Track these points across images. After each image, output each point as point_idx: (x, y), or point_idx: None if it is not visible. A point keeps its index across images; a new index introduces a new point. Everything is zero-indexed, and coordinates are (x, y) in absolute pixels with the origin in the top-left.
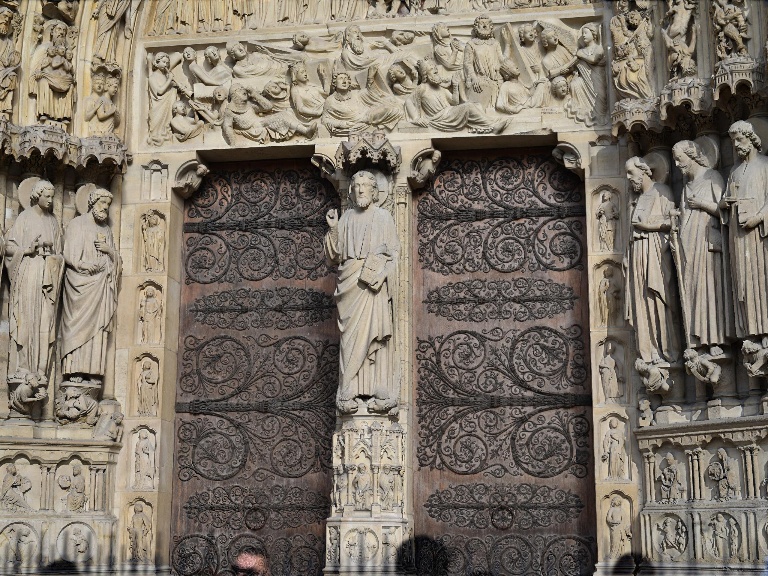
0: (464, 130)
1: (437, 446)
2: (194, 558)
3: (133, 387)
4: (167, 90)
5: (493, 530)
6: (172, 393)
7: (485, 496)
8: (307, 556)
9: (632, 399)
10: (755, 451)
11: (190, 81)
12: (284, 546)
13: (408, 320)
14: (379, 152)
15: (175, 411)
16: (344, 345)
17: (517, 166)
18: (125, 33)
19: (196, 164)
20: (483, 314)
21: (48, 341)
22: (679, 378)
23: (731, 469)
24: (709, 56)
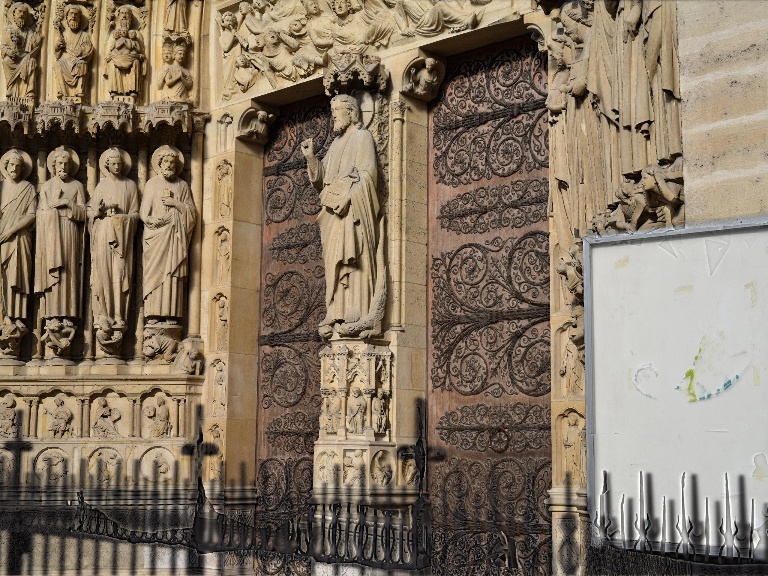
0: (445, 31)
1: (446, 367)
2: (272, 479)
3: (213, 325)
4: (233, 46)
5: (492, 453)
6: (251, 328)
7: (485, 417)
8: None
9: None
10: None
11: None
12: None
13: (405, 239)
14: (348, 73)
15: (259, 344)
16: None
17: (516, 58)
18: (194, 2)
19: (254, 111)
20: (485, 224)
21: (120, 290)
22: None
23: None
24: None
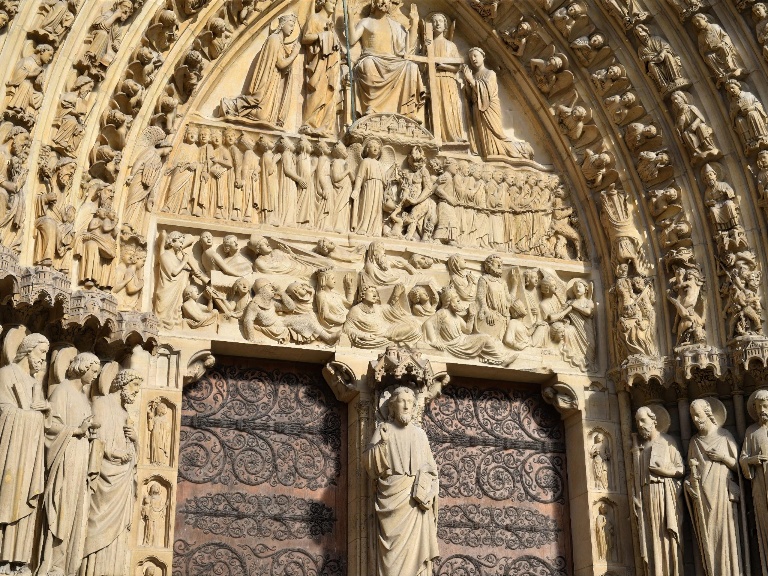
0: (476, 359)
1: None
2: None
3: None
4: (180, 272)
5: None
6: None
7: None
8: None
9: None
10: None
11: (200, 266)
12: None
13: None
14: (423, 371)
15: None
16: (389, 563)
17: (505, 398)
18: (147, 205)
19: (208, 354)
20: (478, 539)
21: None
22: None
23: None
24: (717, 329)
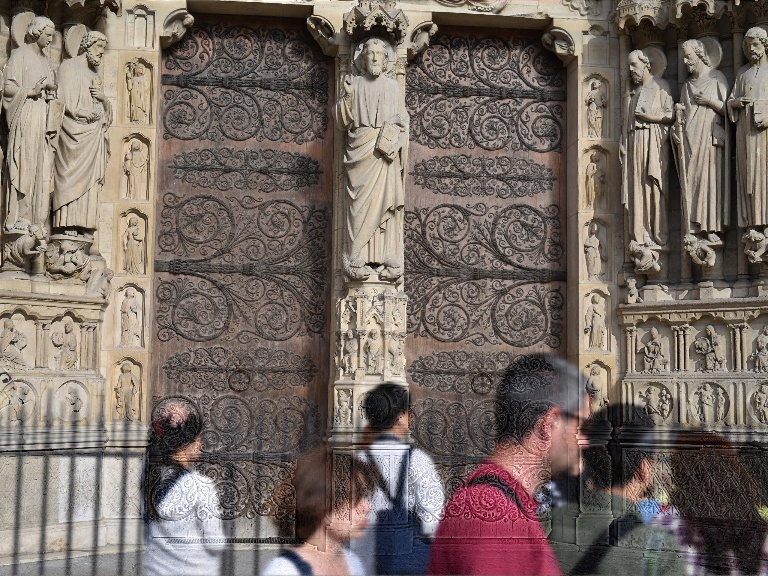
0: (464, 6)
1: (421, 314)
2: (175, 418)
3: (118, 243)
4: None
5: (473, 395)
6: (153, 251)
7: (466, 363)
8: (292, 417)
9: (614, 277)
10: (745, 329)
11: None
12: (269, 407)
13: None
14: (394, 21)
15: (154, 270)
16: (355, 212)
17: (503, 46)
18: None
19: (185, 13)
20: (468, 189)
21: (49, 191)
22: (666, 260)
23: (719, 344)
24: None
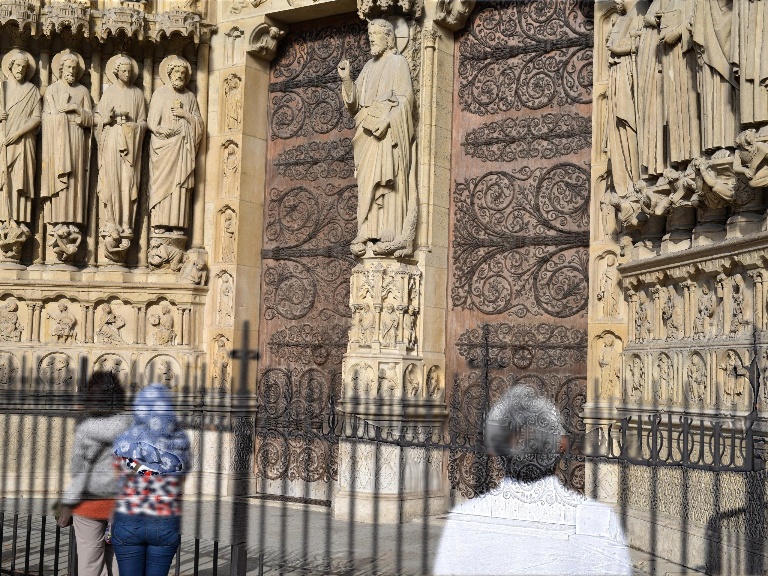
0: None
1: (468, 287)
2: (275, 389)
3: (218, 236)
4: None
5: (514, 369)
6: (256, 241)
7: (508, 335)
8: None
9: None
10: (691, 288)
11: None
12: None
13: (434, 164)
14: None
15: (262, 257)
16: (358, 191)
17: None
18: None
19: (266, 27)
20: (513, 153)
21: (129, 198)
22: None
23: (676, 307)
24: None
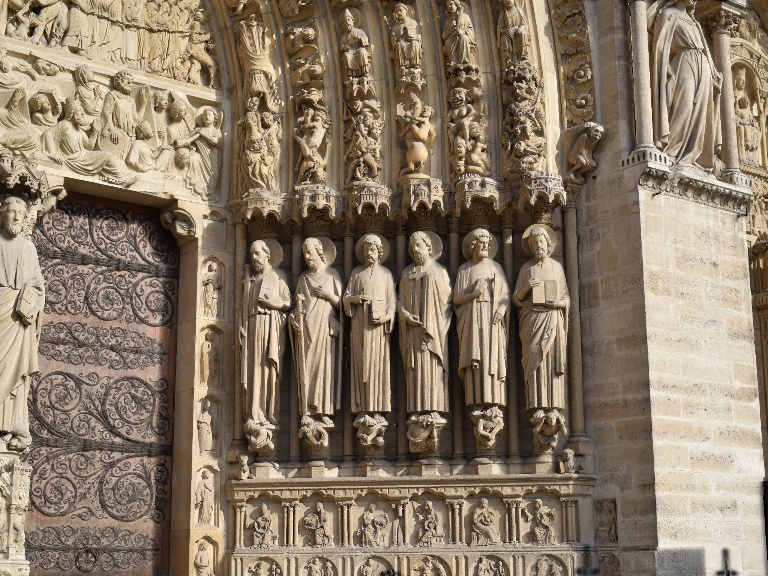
0: (95, 176)
1: None
2: None
3: None
4: None
5: (76, 572)
6: None
7: (71, 538)
8: None
9: (224, 453)
10: (352, 506)
11: None
12: None
13: None
14: (38, 182)
15: None
16: None
17: (122, 219)
18: None
19: None
20: (81, 358)
21: None
22: (276, 439)
23: (328, 520)
24: (337, 172)
